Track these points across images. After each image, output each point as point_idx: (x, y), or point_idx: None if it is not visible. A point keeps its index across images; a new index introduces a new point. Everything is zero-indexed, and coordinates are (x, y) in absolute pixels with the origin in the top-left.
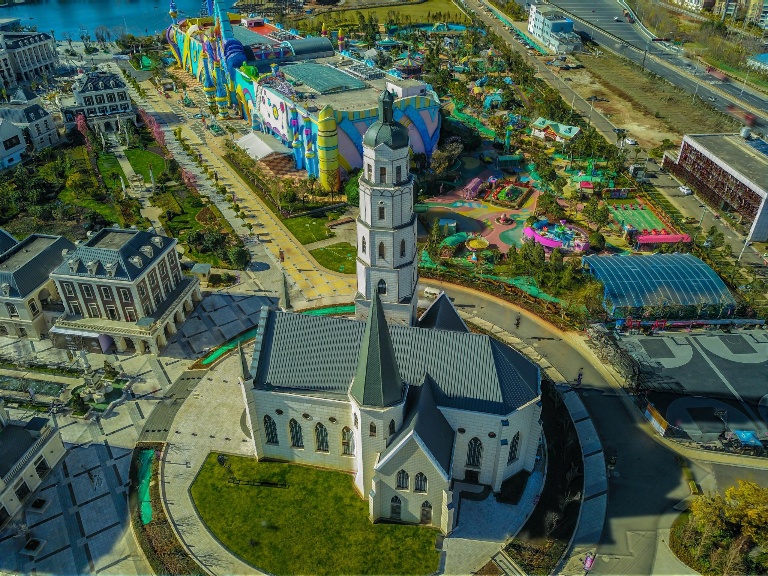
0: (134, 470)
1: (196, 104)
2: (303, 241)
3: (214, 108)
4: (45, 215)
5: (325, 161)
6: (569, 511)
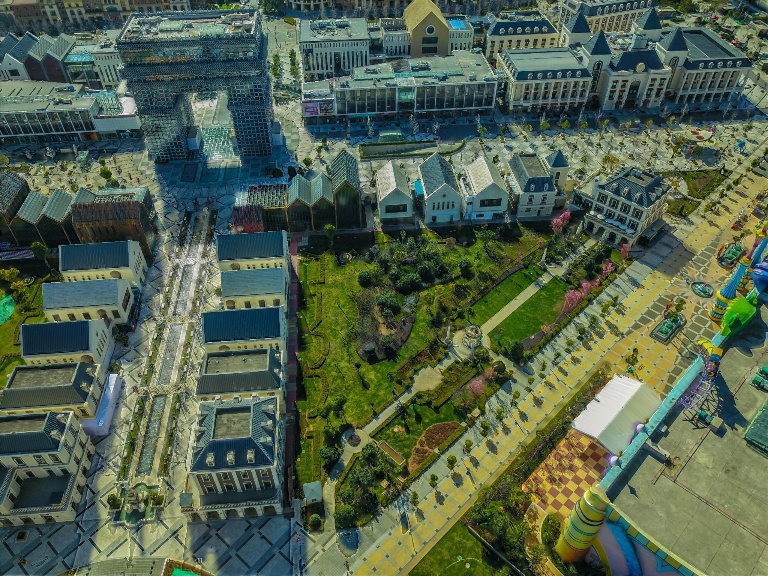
0: None
1: (737, 264)
2: (417, 571)
3: (680, 308)
4: (384, 305)
5: (567, 528)
6: None
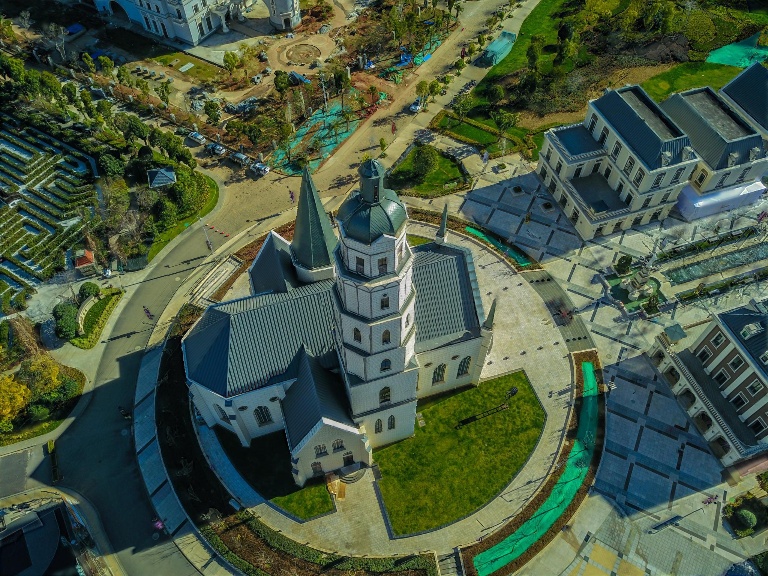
0: (516, 248)
1: None
2: None
3: None
4: None
5: None
6: (167, 366)
